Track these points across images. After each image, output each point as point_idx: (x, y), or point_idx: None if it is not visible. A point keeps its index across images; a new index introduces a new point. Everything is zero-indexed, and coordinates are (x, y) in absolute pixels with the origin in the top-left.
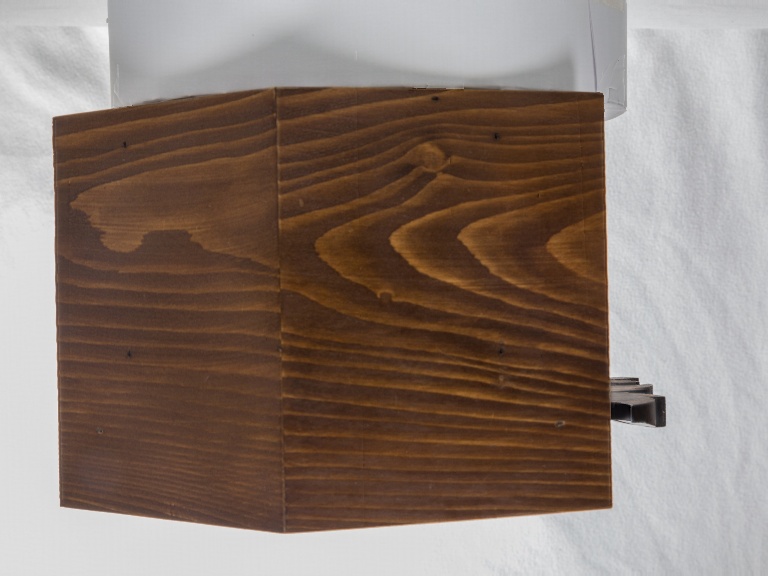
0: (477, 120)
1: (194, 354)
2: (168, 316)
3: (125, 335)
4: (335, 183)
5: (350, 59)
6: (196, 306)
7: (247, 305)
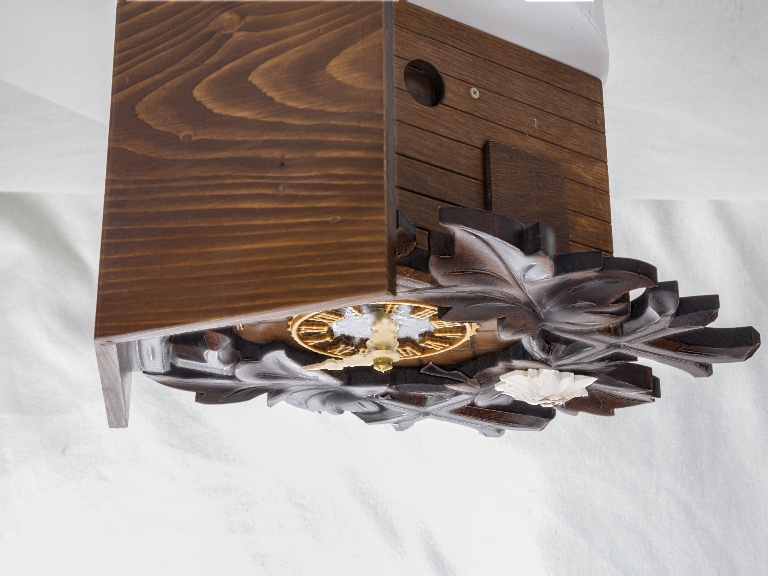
0: None
1: None
2: None
3: None
4: (154, 60)
5: None
6: None
7: None
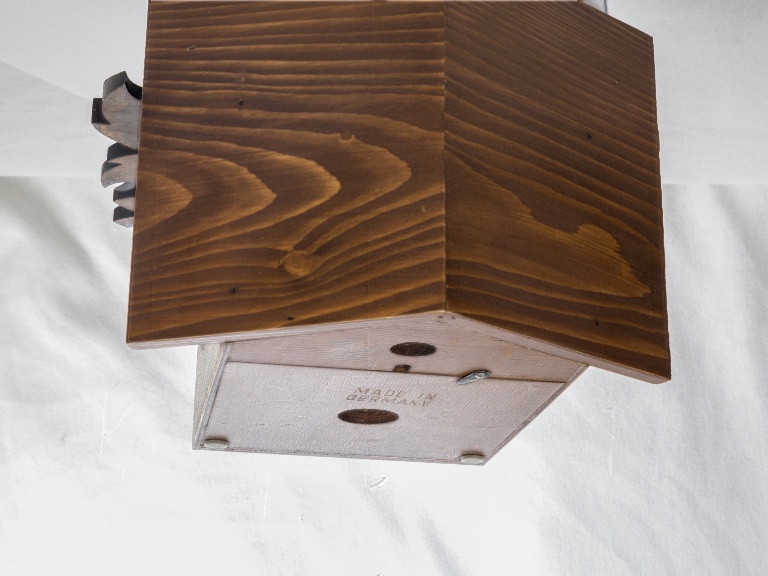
0: (251, 303)
1: (527, 111)
2: (552, 153)
3: (594, 154)
4: (391, 230)
5: (377, 474)
6: (525, 150)
7: (477, 131)
